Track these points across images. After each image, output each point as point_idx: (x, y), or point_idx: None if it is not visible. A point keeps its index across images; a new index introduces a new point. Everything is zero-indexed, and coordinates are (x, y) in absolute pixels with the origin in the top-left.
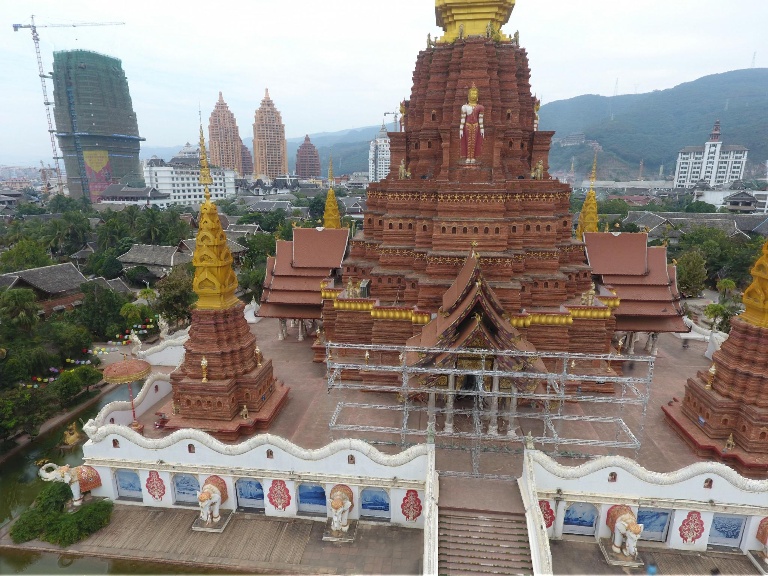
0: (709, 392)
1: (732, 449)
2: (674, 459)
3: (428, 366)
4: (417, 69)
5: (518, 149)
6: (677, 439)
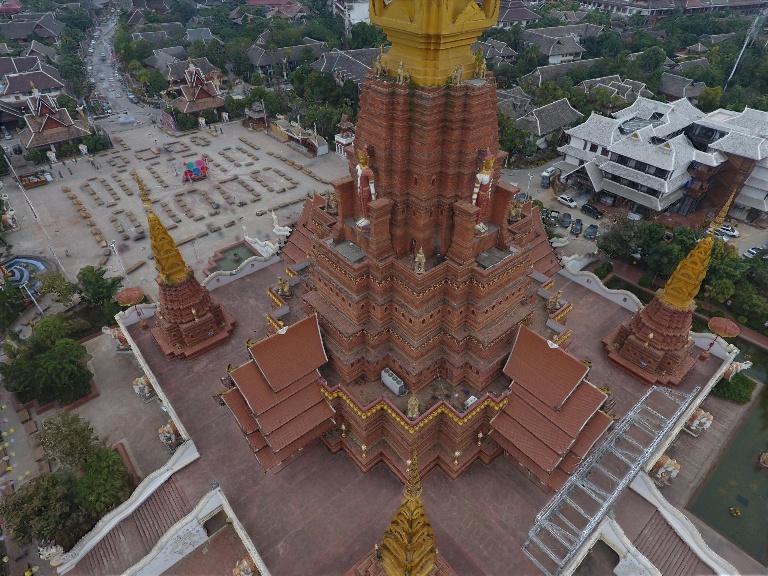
0: (651, 349)
1: (665, 377)
2: None
3: (565, 457)
4: (387, 111)
5: None
6: (629, 378)
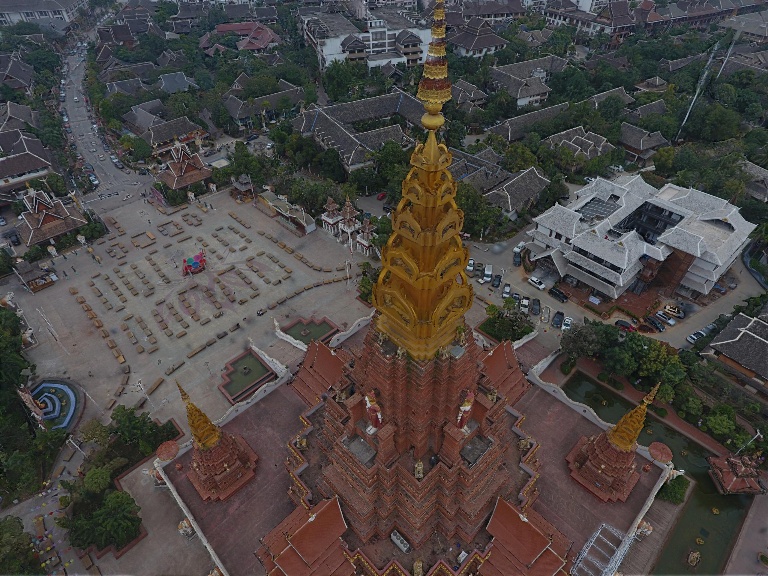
0: (603, 476)
1: (615, 495)
2: (600, 515)
3: None
4: (389, 374)
5: (475, 386)
6: (587, 494)
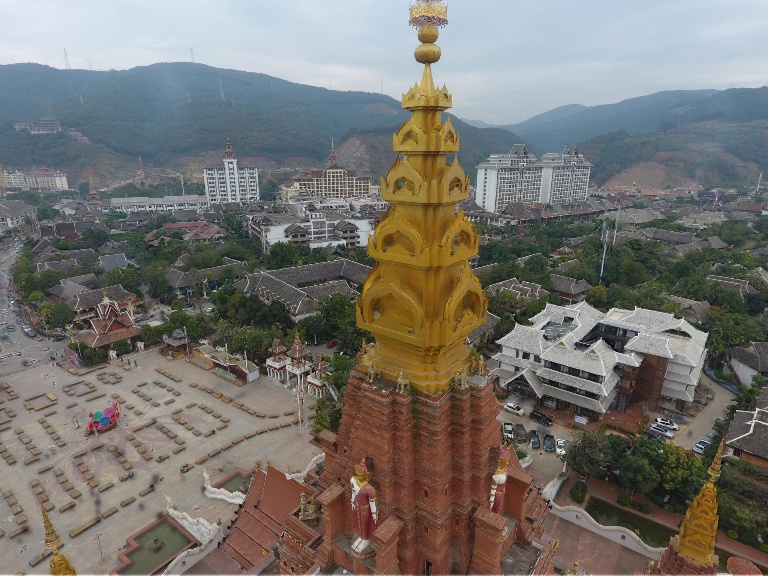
0: None
1: None
2: None
3: None
4: (388, 422)
5: None
6: None
